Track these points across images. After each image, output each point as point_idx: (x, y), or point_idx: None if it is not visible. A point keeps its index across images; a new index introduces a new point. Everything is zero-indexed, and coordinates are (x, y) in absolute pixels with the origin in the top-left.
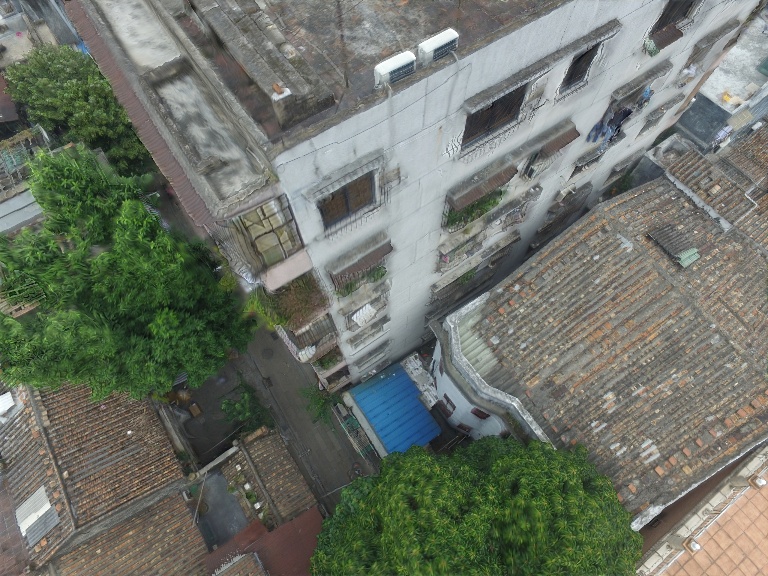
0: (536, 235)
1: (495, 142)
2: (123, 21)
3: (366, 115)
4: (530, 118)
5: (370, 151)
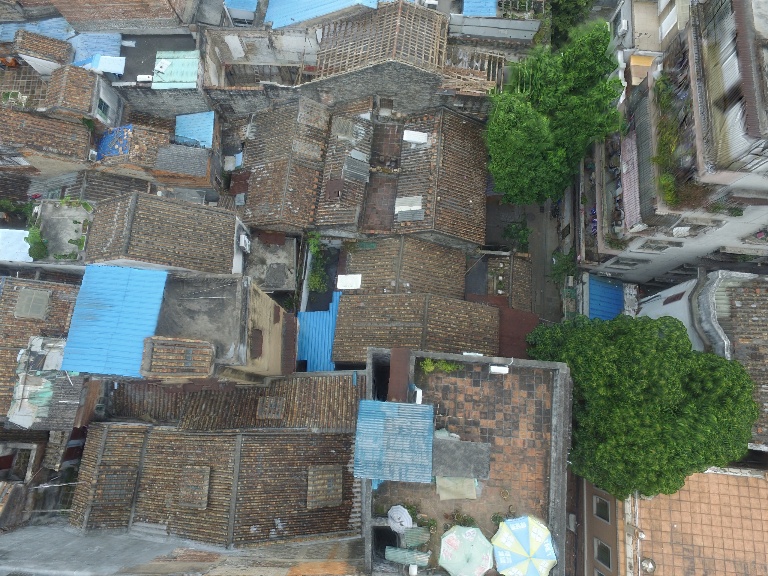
0: None
1: None
2: None
3: None
4: None
5: None
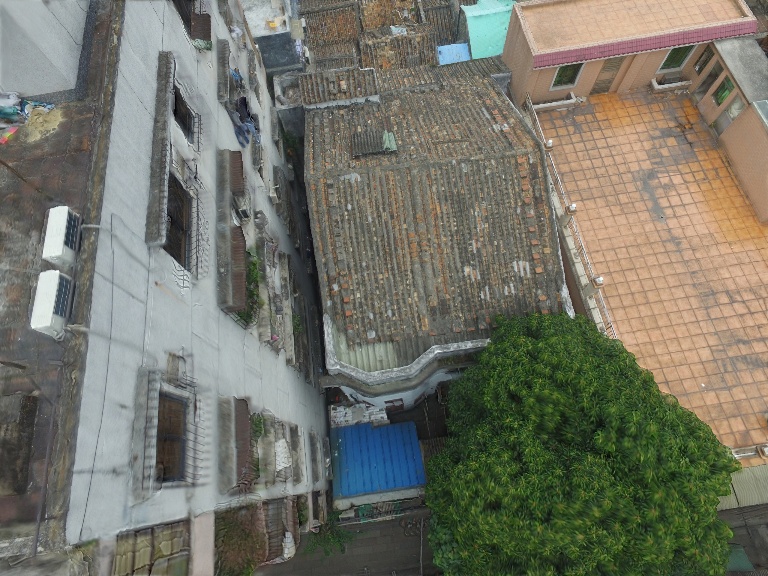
0: (290, 238)
1: (202, 233)
2: None
3: (91, 375)
4: (201, 186)
5: (134, 385)
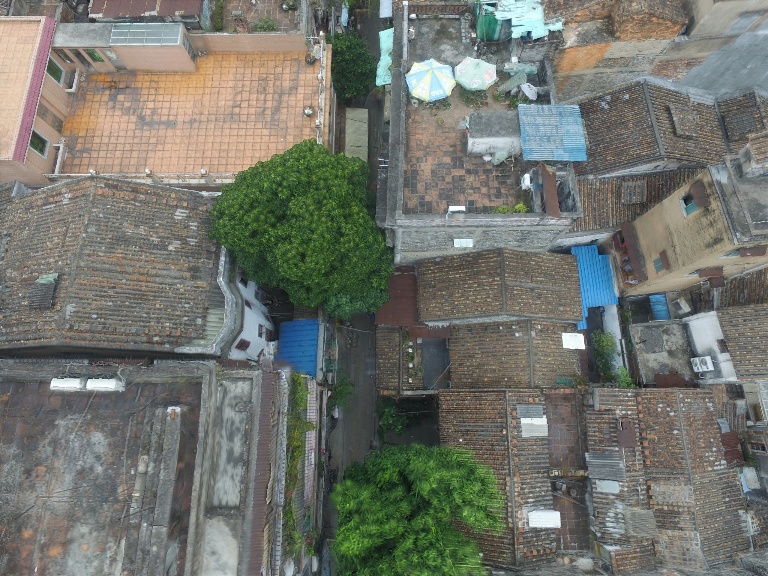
0: None
1: None
2: None
3: (145, 363)
4: None
5: None
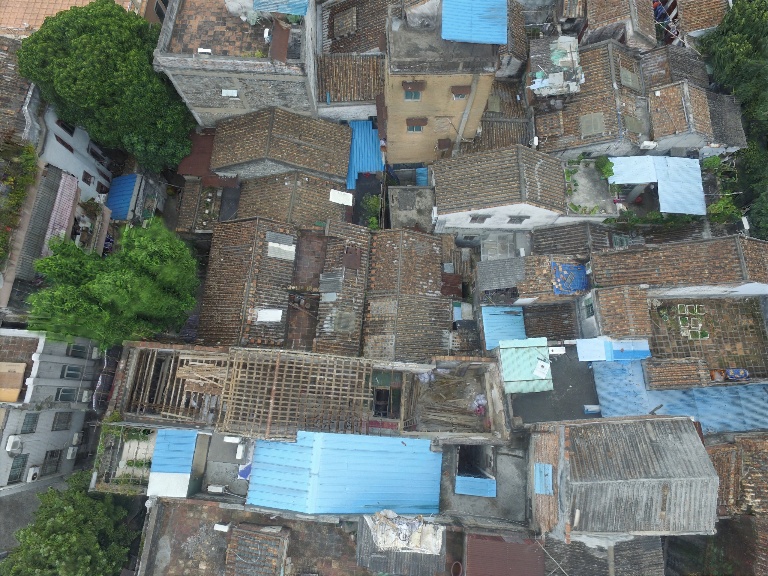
0: None
1: None
2: None
3: None
4: None
5: None
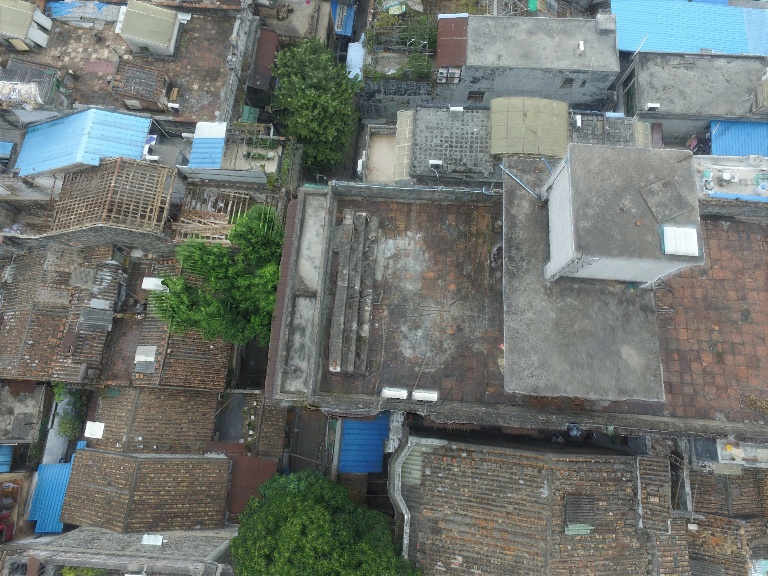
0: None
1: None
2: (310, 234)
3: None
4: None
5: (364, 410)
